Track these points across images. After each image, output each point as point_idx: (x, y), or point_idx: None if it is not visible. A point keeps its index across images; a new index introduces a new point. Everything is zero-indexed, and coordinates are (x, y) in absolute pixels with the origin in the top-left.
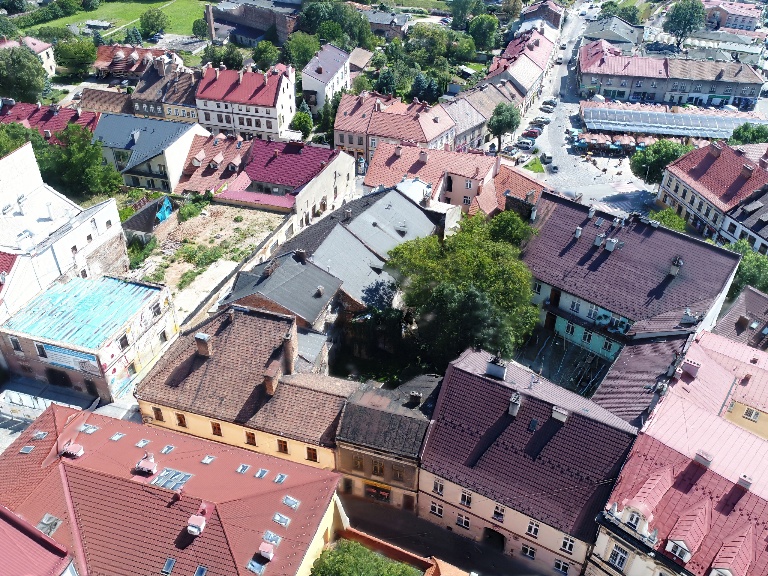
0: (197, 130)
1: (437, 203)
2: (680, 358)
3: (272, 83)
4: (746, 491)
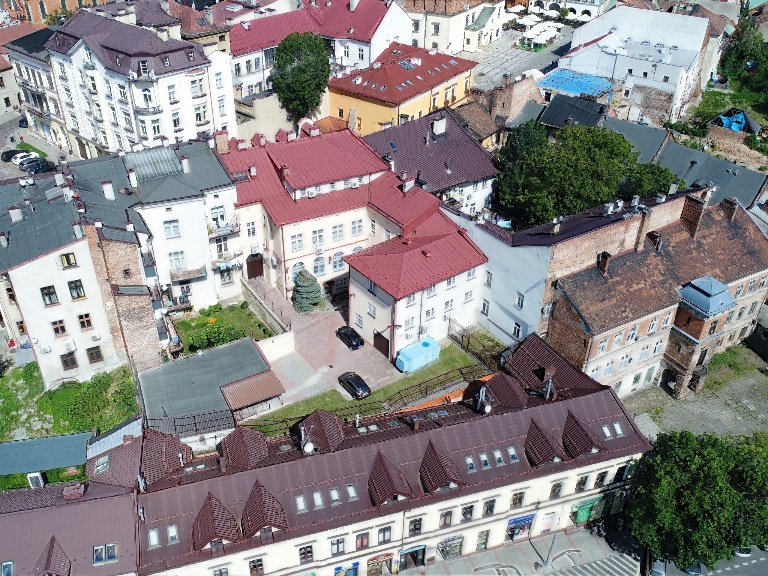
0: None
1: None
2: (424, 187)
3: None
4: None
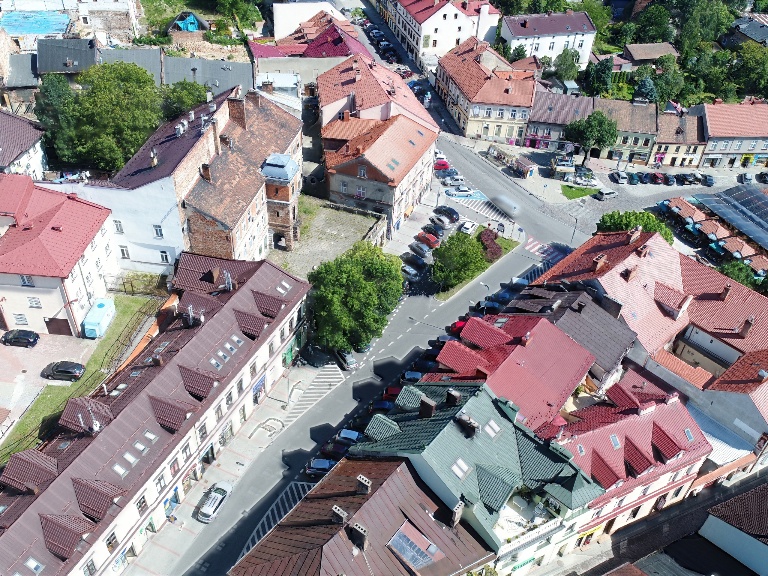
0: (327, 8)
1: (291, 100)
2: None
3: (438, 6)
4: None
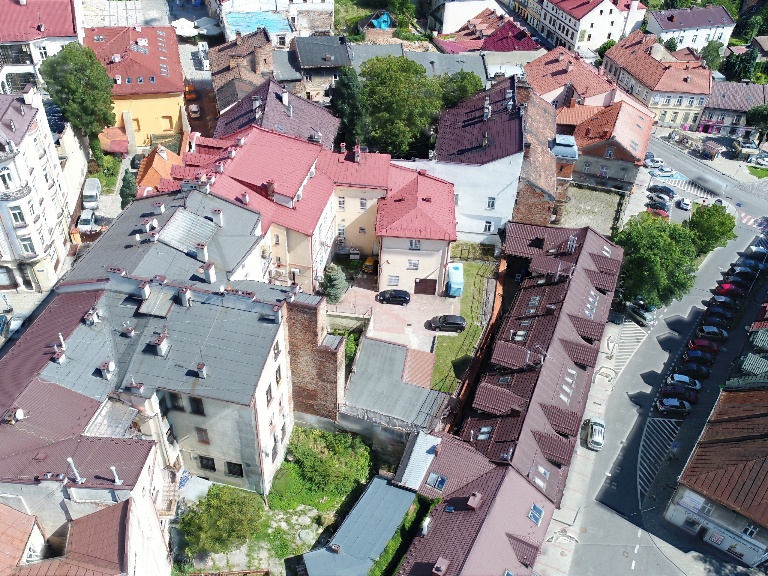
0: (492, 5)
1: None
2: None
3: (595, 2)
4: (229, 158)
